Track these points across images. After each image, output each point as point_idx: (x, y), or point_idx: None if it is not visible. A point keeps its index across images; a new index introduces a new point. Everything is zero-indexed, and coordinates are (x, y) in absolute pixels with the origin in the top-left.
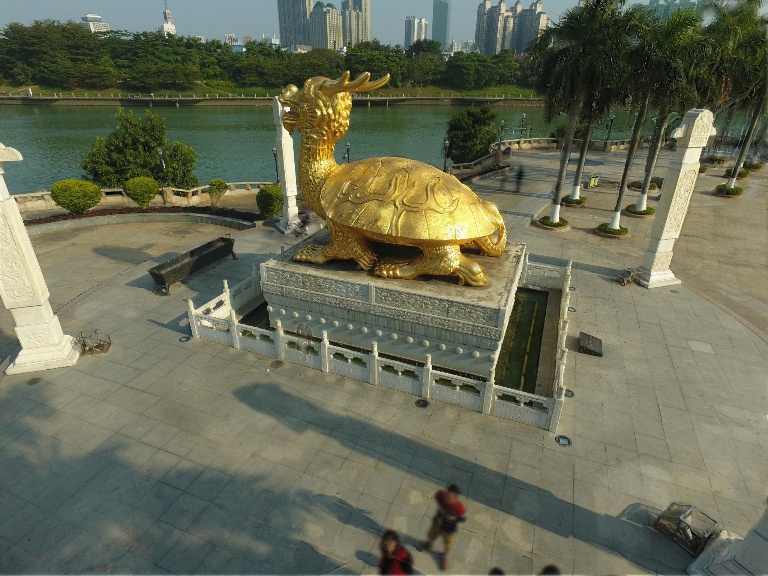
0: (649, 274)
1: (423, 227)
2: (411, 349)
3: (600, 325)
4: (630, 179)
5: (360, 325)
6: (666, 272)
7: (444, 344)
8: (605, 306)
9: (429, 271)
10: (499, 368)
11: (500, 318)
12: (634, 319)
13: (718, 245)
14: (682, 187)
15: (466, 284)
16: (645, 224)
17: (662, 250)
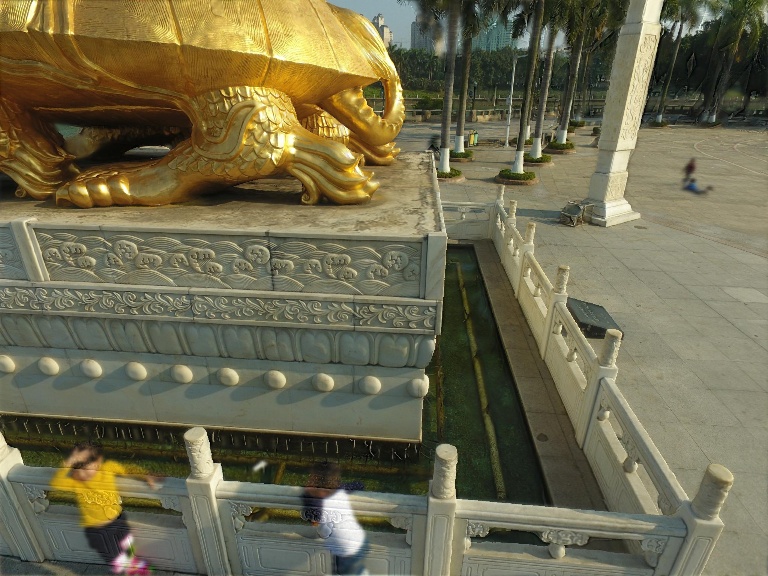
0: (603, 206)
1: (155, 8)
2: (193, 399)
3: (579, 283)
4: (509, 137)
5: (34, 354)
6: (622, 202)
7: (280, 371)
8: (567, 254)
9: (211, 169)
10: (428, 403)
11: (431, 267)
12: (622, 267)
13: (636, 183)
14: (641, 62)
15: (322, 201)
16: (546, 171)
17: (616, 168)
